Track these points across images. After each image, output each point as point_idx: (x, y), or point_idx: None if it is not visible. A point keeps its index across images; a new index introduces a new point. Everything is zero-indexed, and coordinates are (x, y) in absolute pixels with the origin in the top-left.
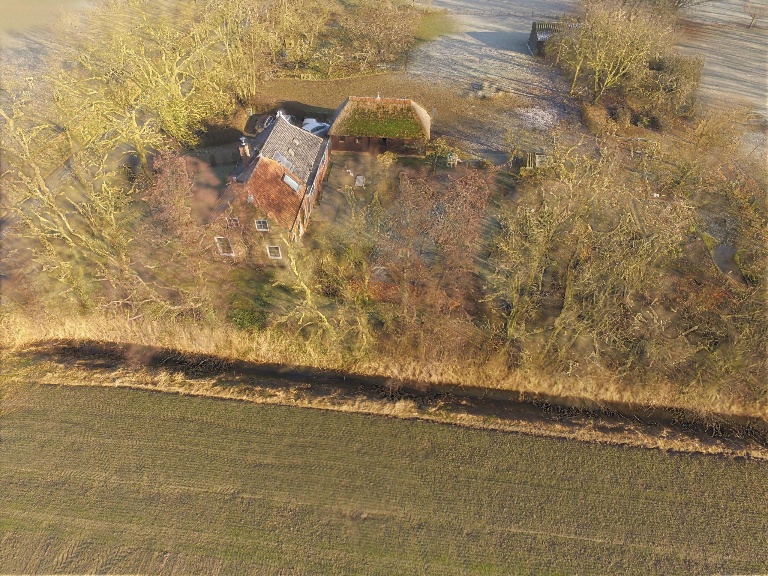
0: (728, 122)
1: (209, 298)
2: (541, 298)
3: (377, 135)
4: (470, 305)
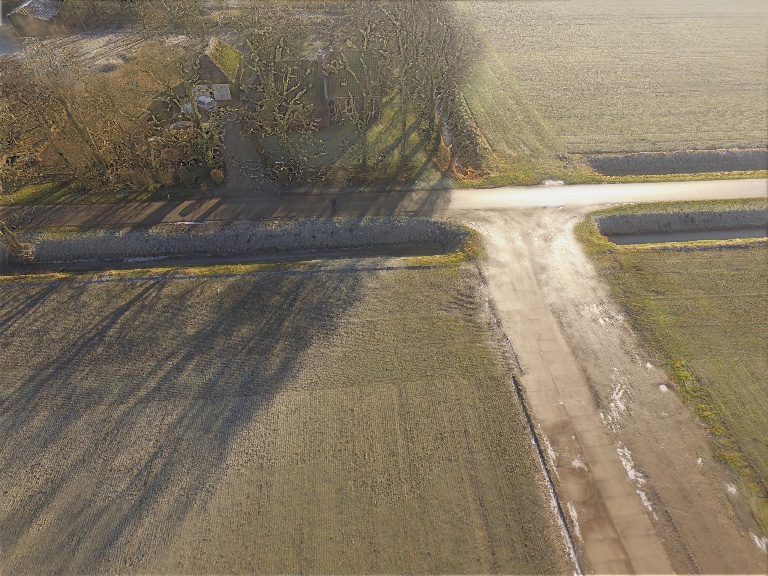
0: (197, 0)
1: None
2: None
3: (237, 66)
4: None
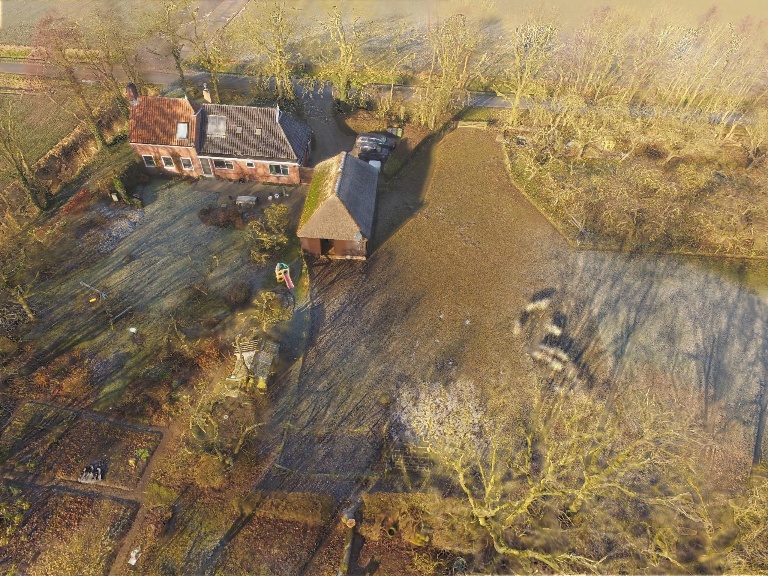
0: None
1: (94, 128)
2: (8, 325)
3: None
4: (35, 270)
